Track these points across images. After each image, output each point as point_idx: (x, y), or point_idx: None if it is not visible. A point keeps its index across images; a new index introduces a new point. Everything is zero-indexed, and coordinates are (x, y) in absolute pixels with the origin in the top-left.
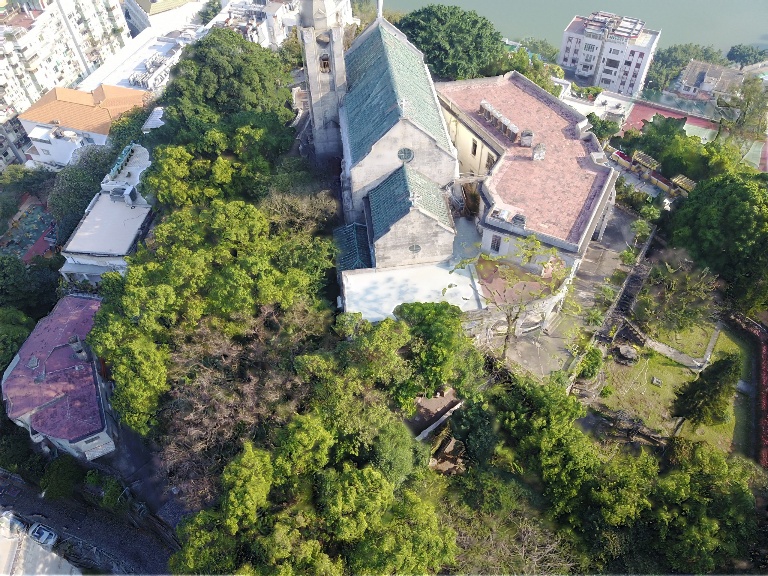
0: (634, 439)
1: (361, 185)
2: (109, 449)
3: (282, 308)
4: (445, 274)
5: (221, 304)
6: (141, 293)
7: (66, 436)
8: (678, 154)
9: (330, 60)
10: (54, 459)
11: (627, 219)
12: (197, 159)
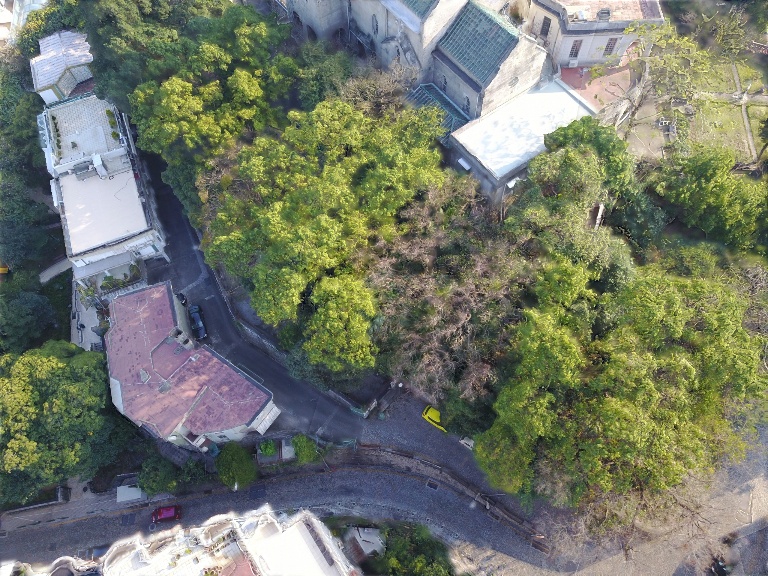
0: (731, 177)
1: (430, 38)
2: (276, 415)
3: (439, 188)
4: (541, 98)
5: (380, 210)
6: (307, 233)
7: (240, 422)
8: None
9: None
10: (221, 454)
11: None
12: (197, 85)
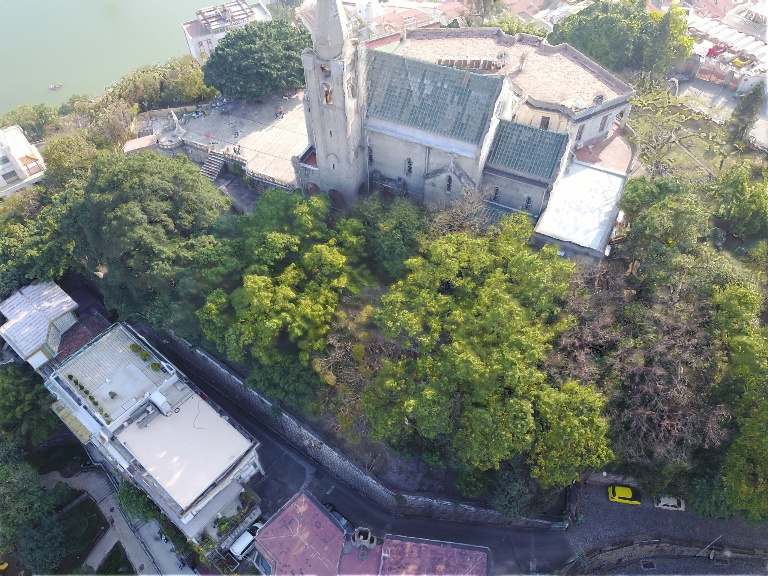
0: None
1: (481, 159)
2: None
3: None
4: (574, 179)
5: None
6: None
7: None
8: None
9: (354, 81)
10: None
11: None
12: (270, 276)
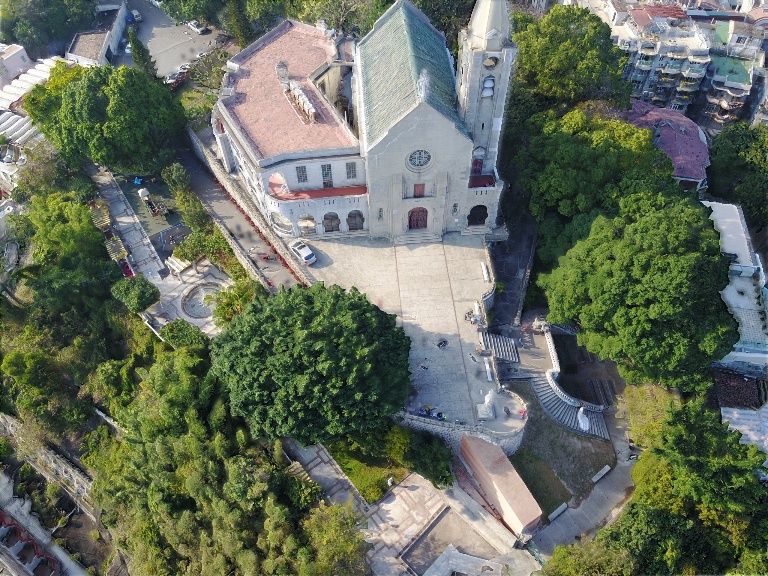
0: None
1: None
2: None
3: None
4: None
5: None
6: None
7: None
8: (89, 224)
9: None
10: None
11: (204, 140)
12: None
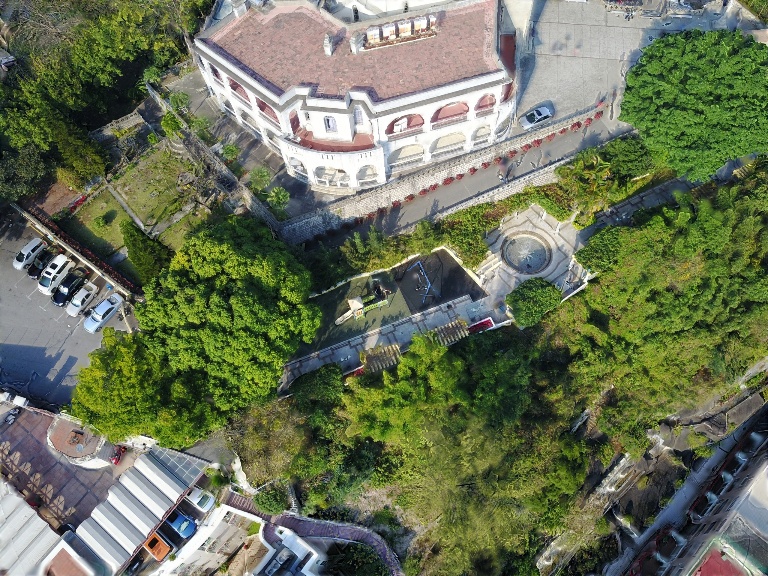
0: None
1: None
2: None
3: None
4: None
5: None
6: None
7: None
8: None
9: None
10: None
11: (309, 210)
12: None
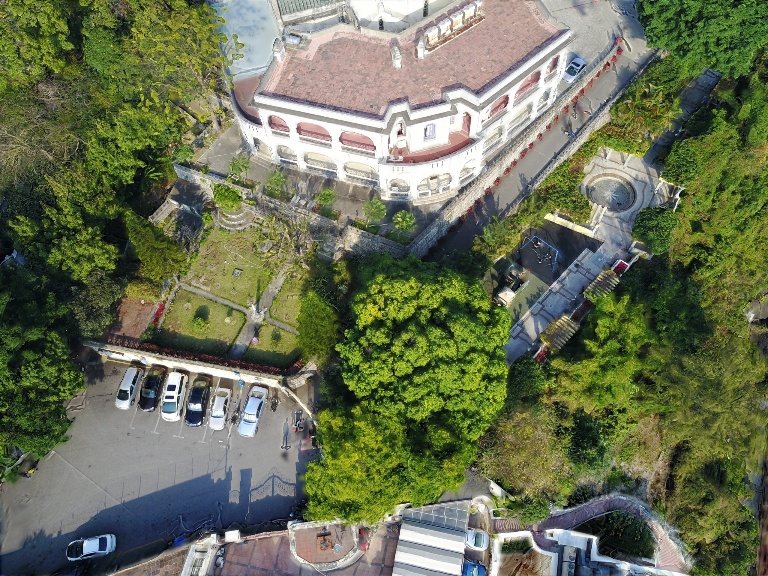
0: None
1: None
2: None
3: None
4: (270, 49)
5: None
6: None
7: None
8: None
9: None
10: None
11: (424, 225)
12: None
